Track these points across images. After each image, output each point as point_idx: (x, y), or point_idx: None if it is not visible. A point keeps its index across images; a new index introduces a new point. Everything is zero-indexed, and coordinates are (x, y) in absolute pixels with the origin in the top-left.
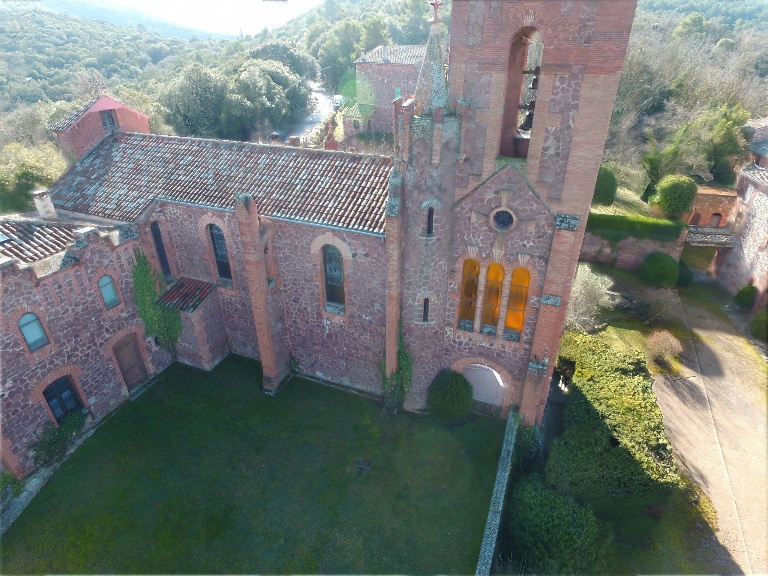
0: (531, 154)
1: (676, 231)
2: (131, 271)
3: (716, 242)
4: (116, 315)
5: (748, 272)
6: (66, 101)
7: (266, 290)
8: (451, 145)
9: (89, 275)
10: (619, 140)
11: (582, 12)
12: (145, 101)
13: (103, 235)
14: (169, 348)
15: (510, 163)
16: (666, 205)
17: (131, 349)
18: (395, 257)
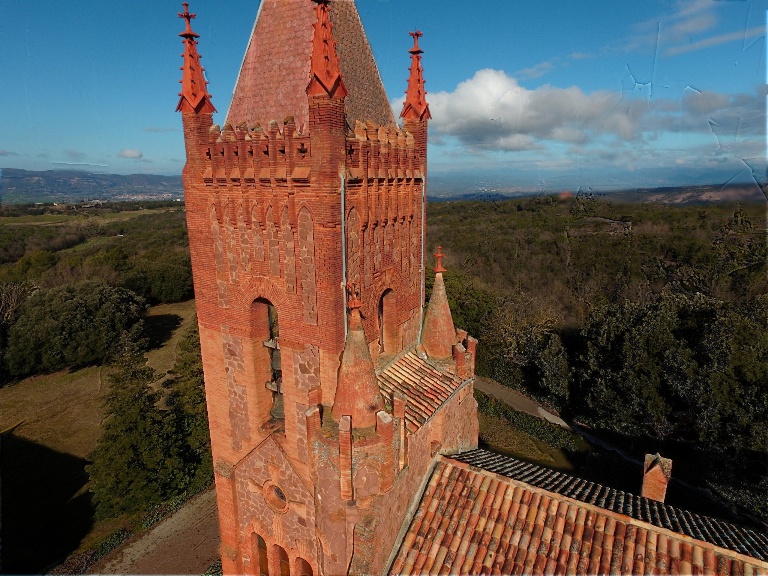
0: None
1: None
2: None
3: None
4: None
5: None
6: None
7: None
8: None
9: None
10: None
11: None
12: None
13: None
14: None
15: None
16: None
17: None
18: None
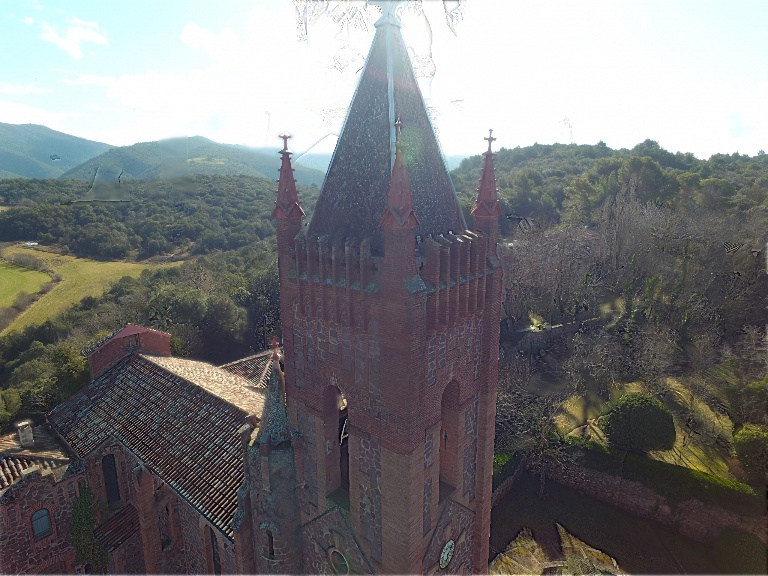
0: (352, 505)
1: (760, 504)
2: (72, 502)
3: None
4: (45, 545)
5: None
6: (170, 287)
7: (158, 555)
8: (284, 474)
9: (24, 510)
10: (685, 368)
11: (371, 388)
12: (239, 282)
13: (46, 474)
14: (102, 575)
15: (337, 507)
16: (746, 464)
17: (59, 575)
18: (242, 570)
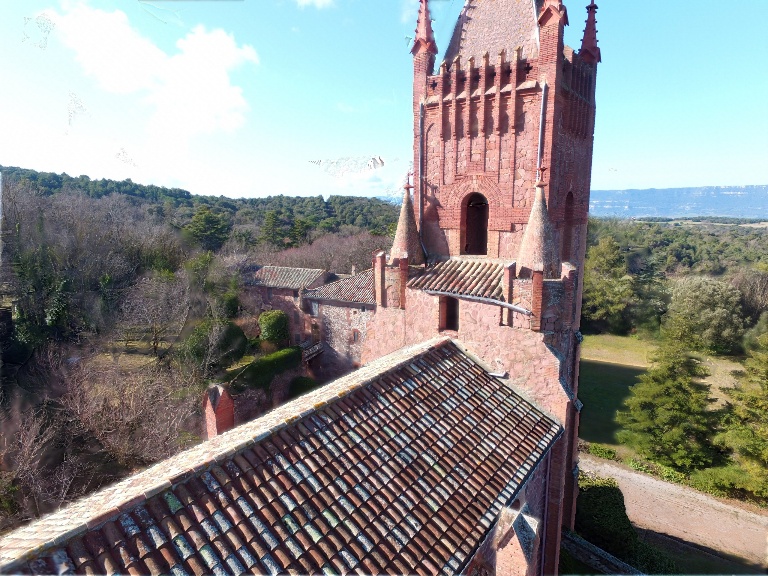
0: None
1: (298, 355)
2: None
3: (315, 352)
4: None
5: (349, 362)
6: None
7: None
8: None
9: None
10: None
11: None
12: None
13: None
14: None
15: None
16: (277, 337)
17: None
18: None
